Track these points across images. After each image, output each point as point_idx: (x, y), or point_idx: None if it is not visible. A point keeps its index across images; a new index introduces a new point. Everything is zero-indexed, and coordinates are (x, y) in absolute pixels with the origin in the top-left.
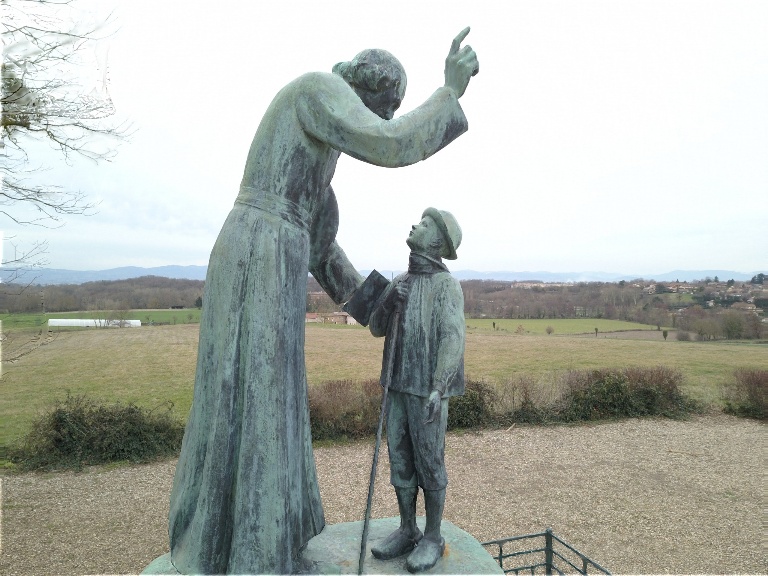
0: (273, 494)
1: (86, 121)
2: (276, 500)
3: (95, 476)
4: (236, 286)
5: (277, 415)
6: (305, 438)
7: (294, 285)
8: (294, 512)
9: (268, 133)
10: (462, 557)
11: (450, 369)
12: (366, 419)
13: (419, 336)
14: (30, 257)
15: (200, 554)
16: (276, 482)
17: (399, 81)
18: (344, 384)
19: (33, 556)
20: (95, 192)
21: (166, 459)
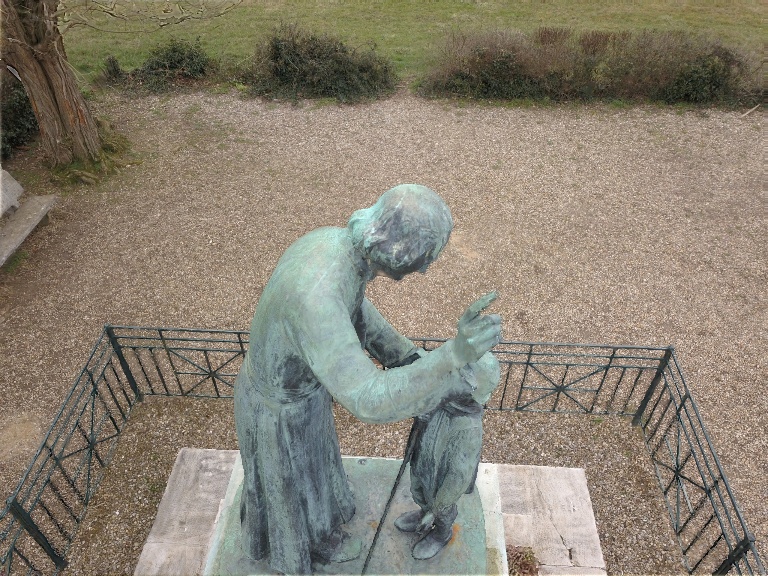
0: (291, 549)
1: None
2: (293, 553)
3: (307, 113)
4: (247, 444)
5: (289, 518)
6: (334, 482)
7: (302, 436)
8: (320, 529)
9: (261, 335)
10: (461, 551)
11: (448, 503)
12: (575, 81)
13: (431, 459)
14: None
15: (251, 551)
16: (292, 545)
17: (432, 248)
18: (561, 32)
19: (257, 201)
20: None
21: (368, 101)
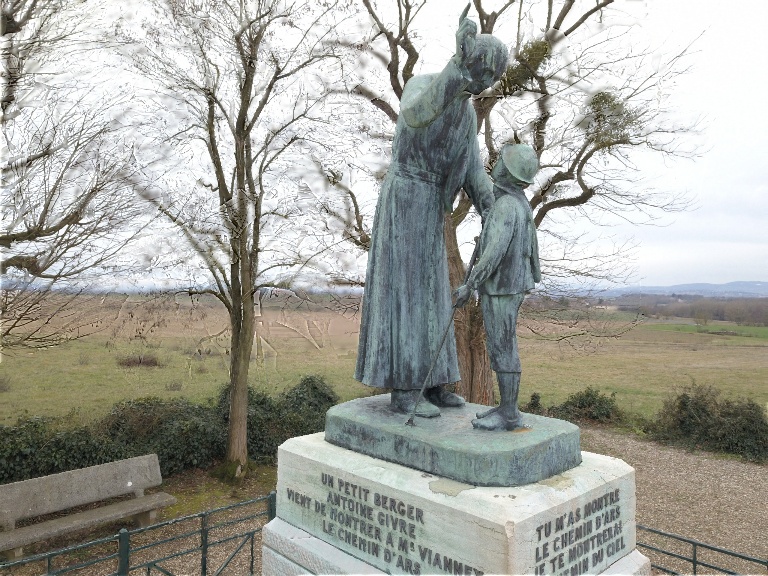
0: (374, 338)
1: (665, 125)
2: (374, 341)
3: (701, 459)
4: (374, 219)
5: (379, 292)
6: (429, 320)
7: (404, 216)
8: (406, 361)
9: None
10: None
11: (477, 268)
12: None
13: None
14: (626, 251)
15: (356, 367)
16: None
17: (485, 54)
18: None
19: None
20: (698, 188)
21: None
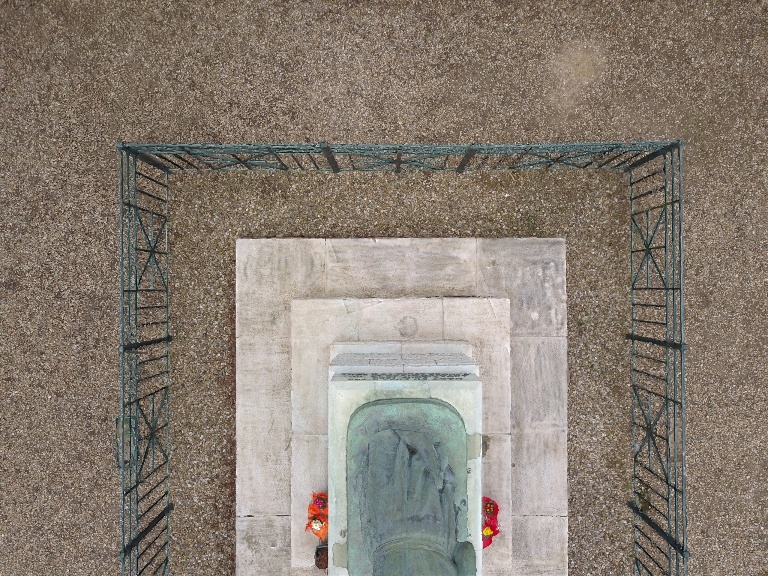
0: None
1: None
2: None
3: None
4: None
5: None
6: None
7: None
8: None
9: None
10: None
11: None
12: None
13: None
14: None
15: None
16: None
17: None
18: None
19: None
20: None
21: None
